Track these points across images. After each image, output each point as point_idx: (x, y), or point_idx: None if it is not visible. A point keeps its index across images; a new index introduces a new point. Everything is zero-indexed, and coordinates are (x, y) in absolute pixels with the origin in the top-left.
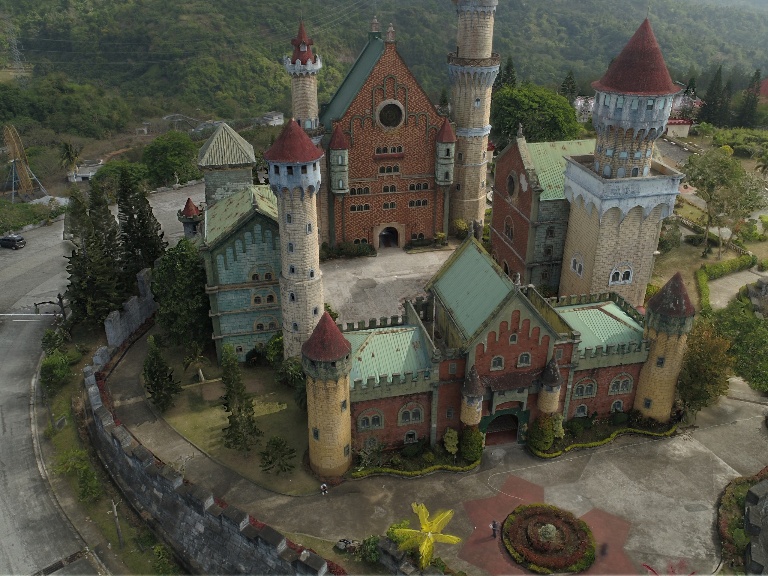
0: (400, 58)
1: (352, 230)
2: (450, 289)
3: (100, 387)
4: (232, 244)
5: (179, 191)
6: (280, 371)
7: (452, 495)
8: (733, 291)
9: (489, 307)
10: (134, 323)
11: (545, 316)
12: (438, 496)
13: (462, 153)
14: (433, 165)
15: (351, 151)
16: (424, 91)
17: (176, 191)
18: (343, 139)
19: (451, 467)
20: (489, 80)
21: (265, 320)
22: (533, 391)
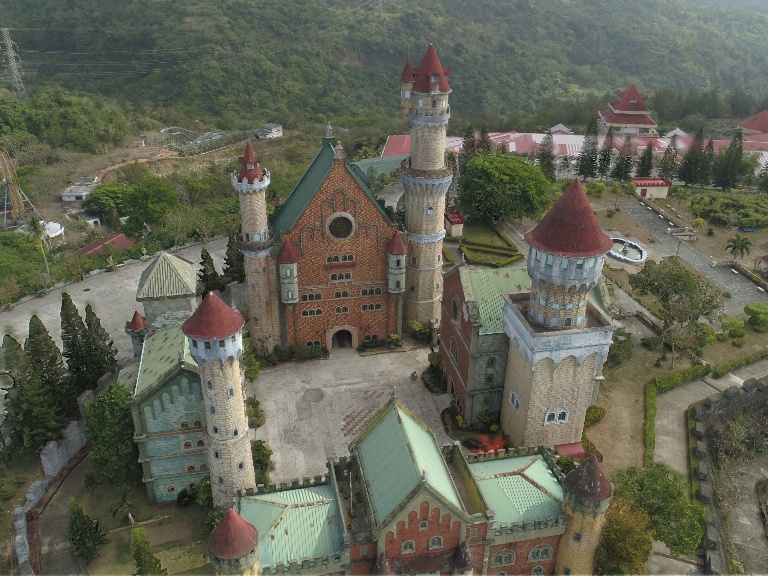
0: (349, 173)
1: (304, 333)
2: (370, 456)
3: (30, 530)
4: (159, 397)
5: (146, 264)
6: (206, 522)
7: None
8: (682, 407)
9: (400, 494)
10: (74, 448)
11: (467, 480)
12: None
13: (416, 257)
14: (385, 271)
15: (301, 260)
16: (374, 203)
17: (143, 263)
18: (291, 253)
19: None
20: (442, 189)
21: (196, 462)
22: (446, 570)
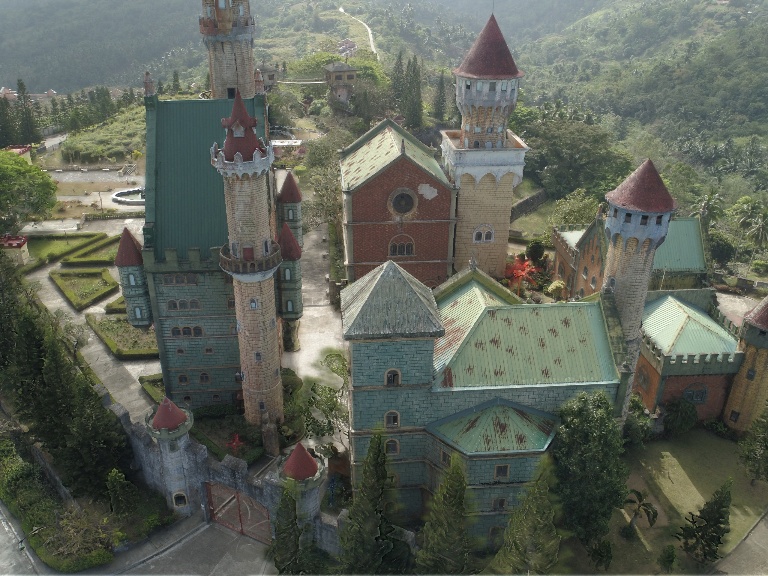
0: (265, 113)
1: None
2: None
3: None
4: None
5: None
6: None
7: None
8: None
9: (691, 241)
10: None
11: None
12: None
13: None
14: None
15: None
16: None
17: None
18: None
19: None
20: None
21: None
22: None
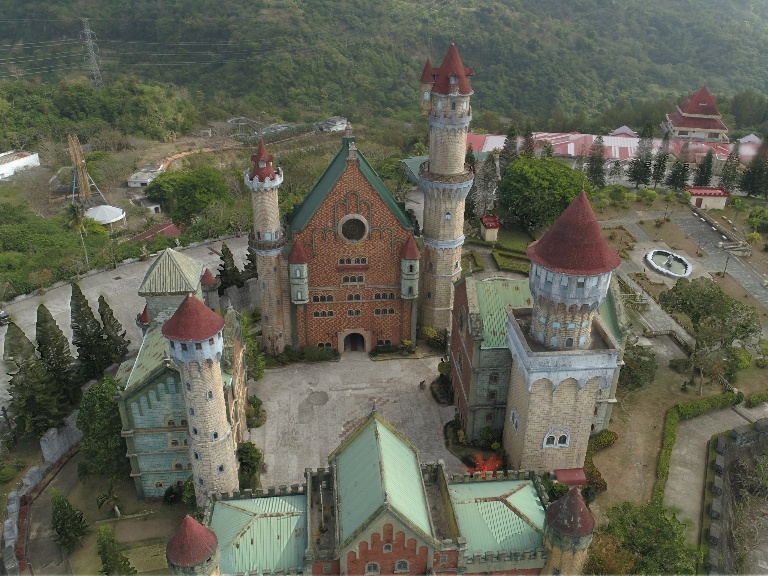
0: (363, 175)
1: (316, 334)
2: (345, 470)
3: (21, 515)
4: (146, 393)
5: None
6: None
7: None
8: (705, 437)
9: (365, 513)
10: (75, 436)
11: (446, 502)
12: None
13: (433, 263)
14: (399, 276)
15: (313, 261)
16: (389, 206)
17: None
18: (301, 253)
19: None
20: (460, 194)
21: (183, 460)
22: None
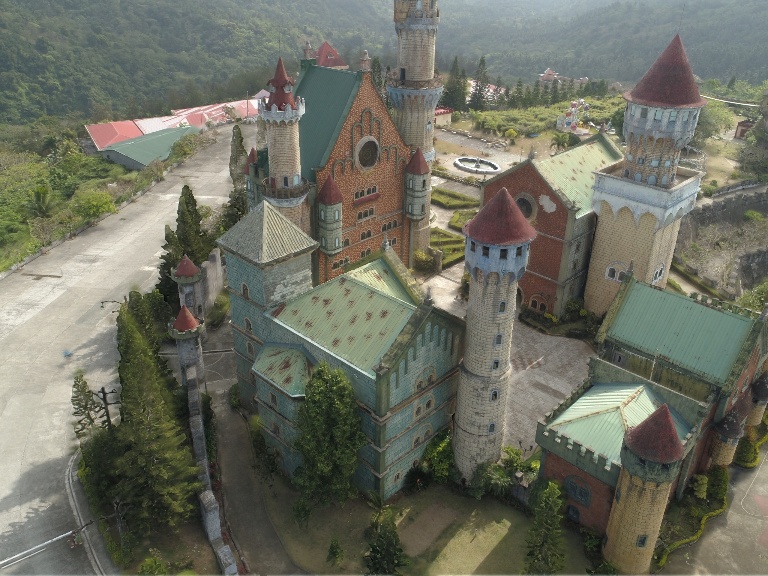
0: (375, 88)
1: None
2: (641, 335)
3: None
4: (405, 355)
5: None
6: (482, 485)
7: (742, 540)
8: None
9: (728, 344)
10: None
11: None
12: (735, 547)
13: None
14: (401, 200)
15: None
16: None
17: None
18: (338, 190)
19: (715, 513)
20: None
21: (422, 431)
22: None
